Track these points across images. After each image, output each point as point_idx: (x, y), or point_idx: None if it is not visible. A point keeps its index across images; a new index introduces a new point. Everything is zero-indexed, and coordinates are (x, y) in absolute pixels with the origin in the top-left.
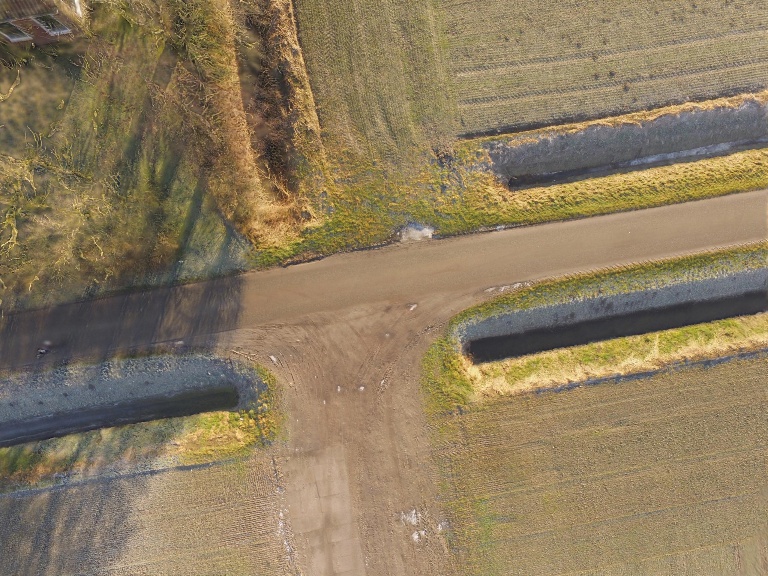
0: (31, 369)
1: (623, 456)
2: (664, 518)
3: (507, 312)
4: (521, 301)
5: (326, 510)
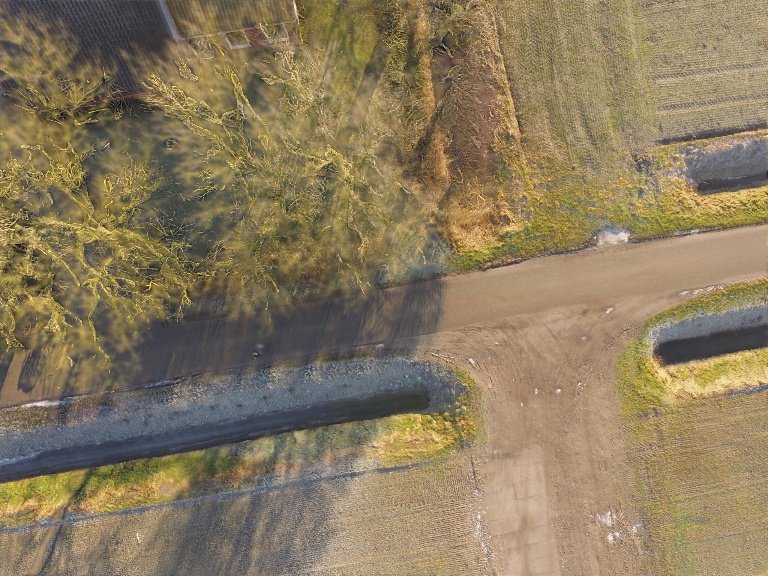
0: (235, 372)
1: None
2: None
3: (700, 315)
4: (714, 304)
5: (523, 512)
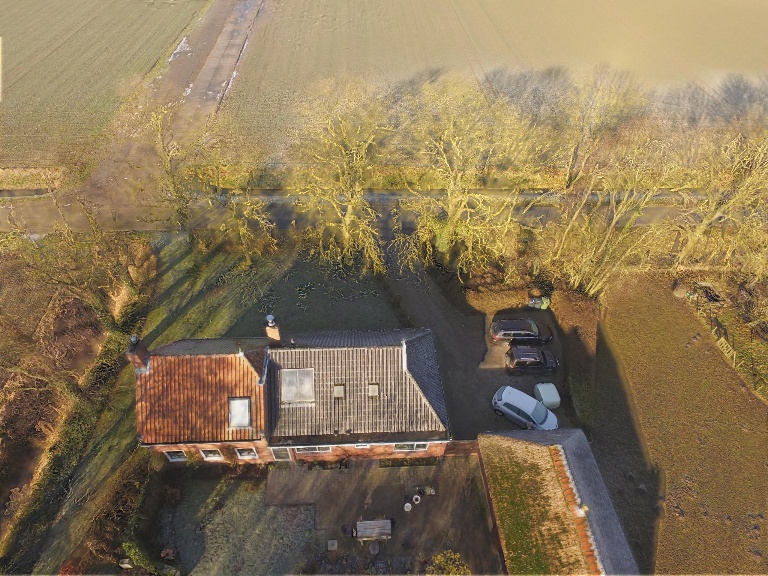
0: None
1: (3, 142)
2: (5, 122)
3: None
4: None
5: None
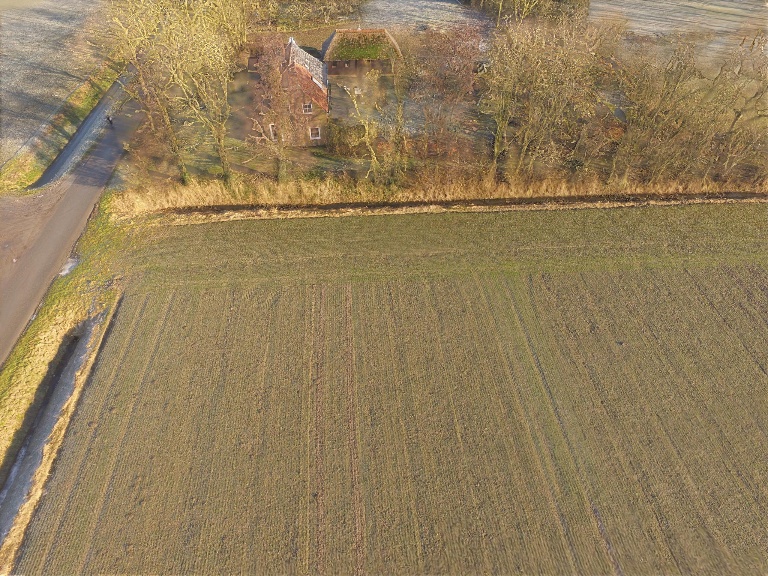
0: None
1: None
2: None
3: None
4: None
5: None
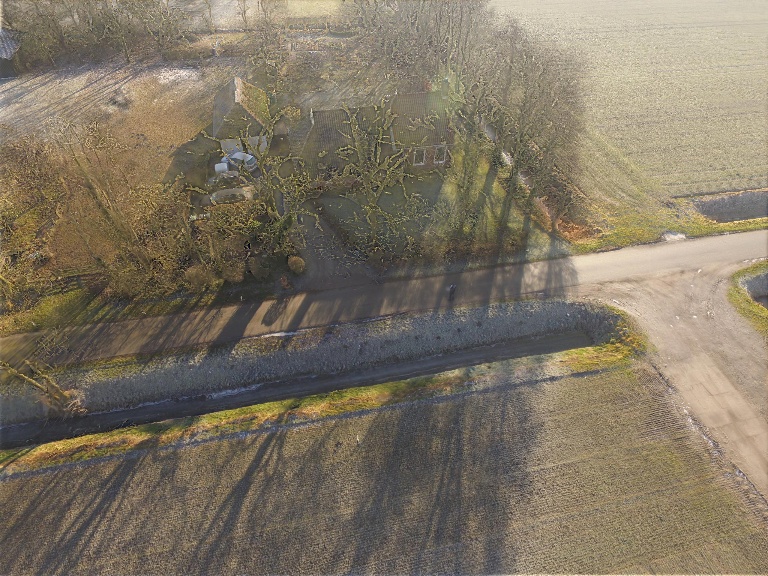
0: (433, 311)
1: None
2: None
3: (767, 272)
4: None
5: (725, 406)
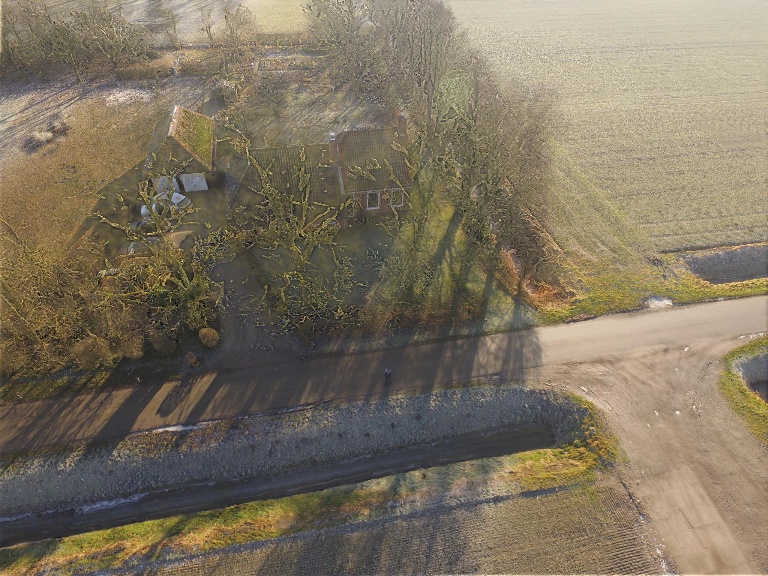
0: (365, 399)
1: None
2: None
3: (767, 352)
4: None
5: (709, 545)
